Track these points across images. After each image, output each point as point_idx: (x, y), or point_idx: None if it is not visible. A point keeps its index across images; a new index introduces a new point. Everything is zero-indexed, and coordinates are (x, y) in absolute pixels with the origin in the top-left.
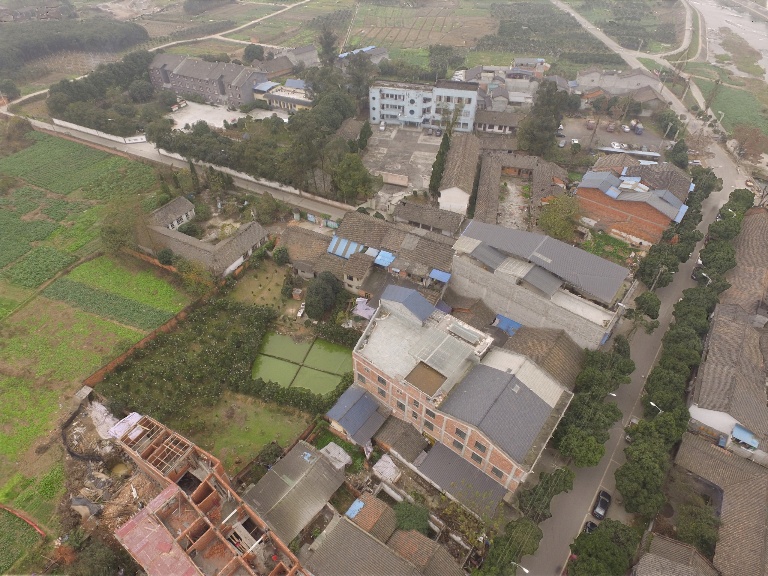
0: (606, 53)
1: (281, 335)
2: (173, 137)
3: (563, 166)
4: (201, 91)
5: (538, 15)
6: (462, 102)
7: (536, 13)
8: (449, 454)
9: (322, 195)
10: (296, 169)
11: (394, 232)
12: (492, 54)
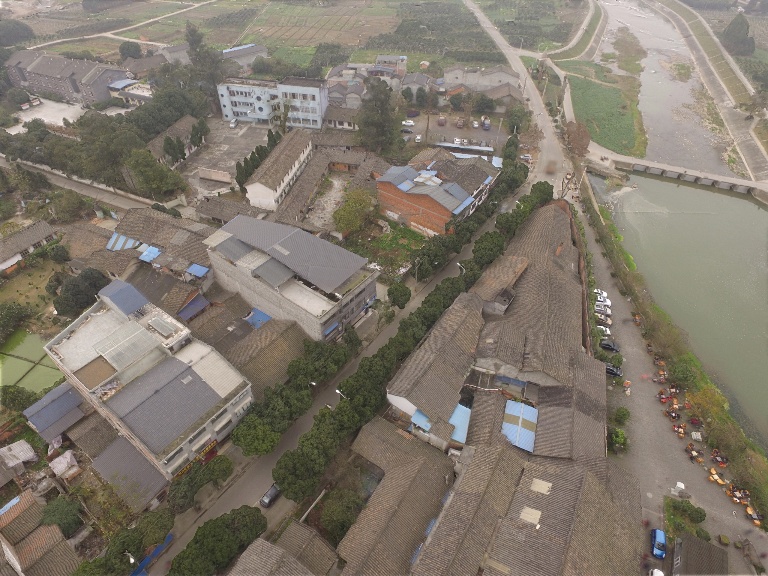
0: (491, 51)
1: None
2: None
3: (395, 161)
4: (57, 89)
5: (442, 14)
6: (307, 99)
7: (441, 12)
8: (127, 448)
9: (134, 192)
10: (97, 166)
11: (168, 228)
12: (379, 52)
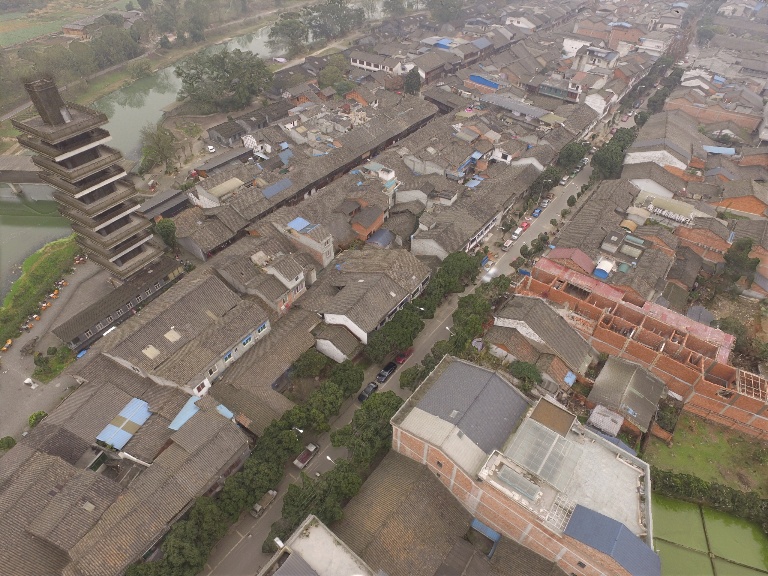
0: None
1: None
2: None
3: None
4: None
5: None
6: None
7: None
8: None
9: None
10: None
11: None
12: None
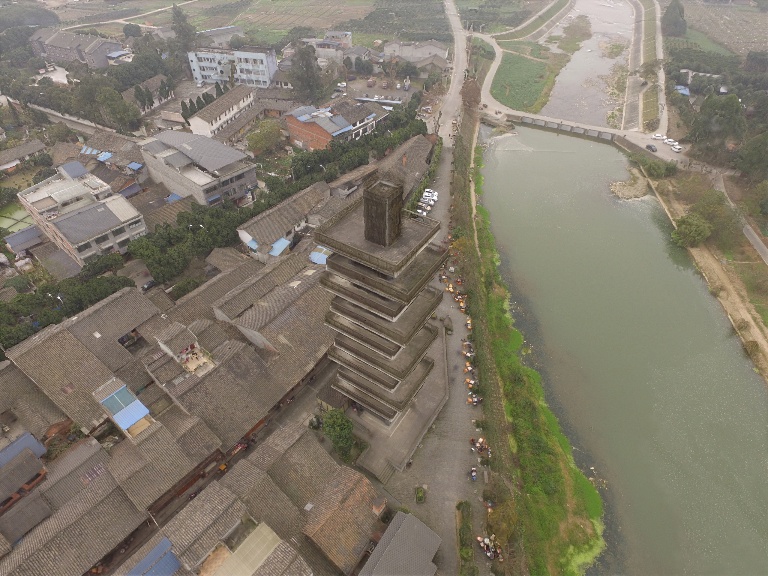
0: (443, 33)
1: (19, 206)
2: (10, 85)
3: None
4: (67, 58)
5: (414, 4)
6: (257, 63)
7: (414, 2)
8: (64, 255)
9: (109, 126)
10: (80, 103)
11: (120, 140)
12: None
